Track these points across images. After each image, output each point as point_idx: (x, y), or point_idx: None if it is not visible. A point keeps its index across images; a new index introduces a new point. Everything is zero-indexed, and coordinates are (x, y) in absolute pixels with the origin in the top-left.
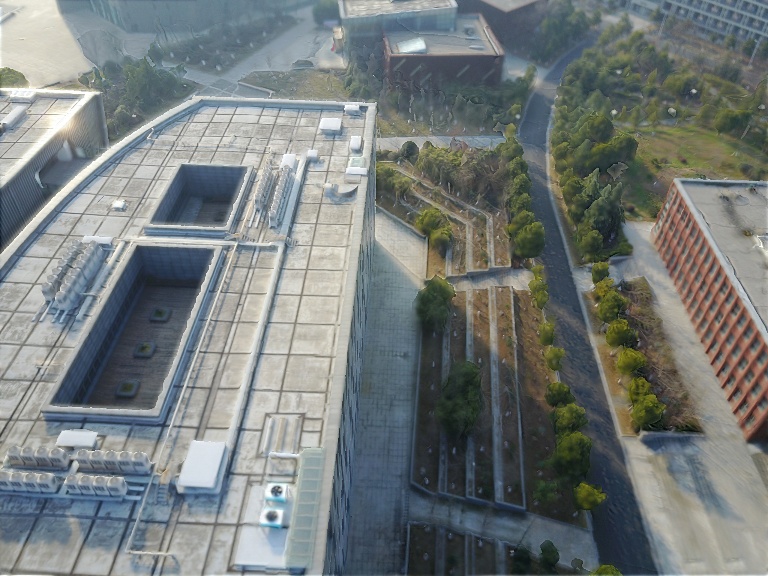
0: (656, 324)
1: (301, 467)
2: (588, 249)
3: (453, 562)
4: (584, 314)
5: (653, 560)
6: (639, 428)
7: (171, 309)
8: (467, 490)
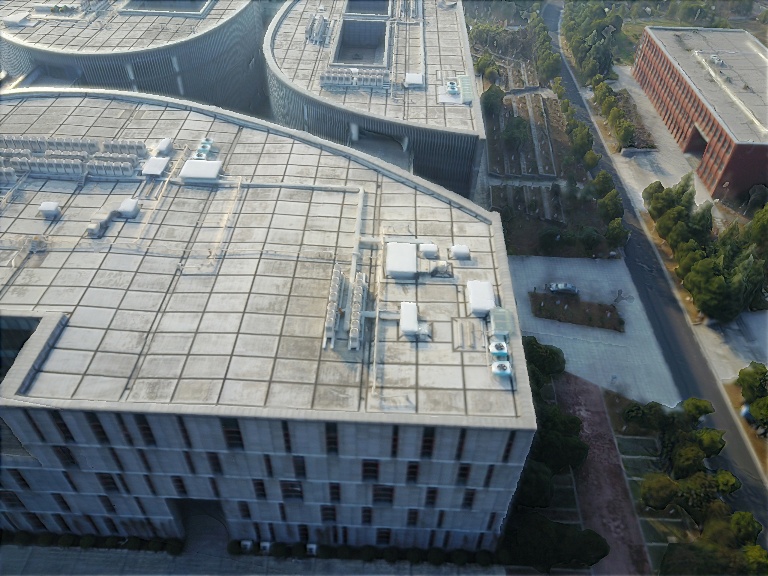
0: (632, 108)
1: (460, 80)
2: (589, 73)
3: (518, 192)
4: (587, 108)
5: (628, 195)
6: (621, 148)
7: (362, 55)
8: (522, 171)
